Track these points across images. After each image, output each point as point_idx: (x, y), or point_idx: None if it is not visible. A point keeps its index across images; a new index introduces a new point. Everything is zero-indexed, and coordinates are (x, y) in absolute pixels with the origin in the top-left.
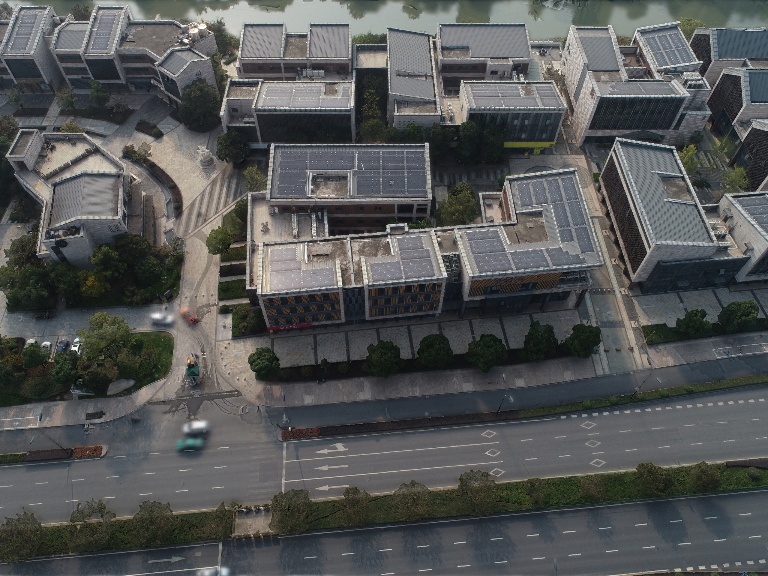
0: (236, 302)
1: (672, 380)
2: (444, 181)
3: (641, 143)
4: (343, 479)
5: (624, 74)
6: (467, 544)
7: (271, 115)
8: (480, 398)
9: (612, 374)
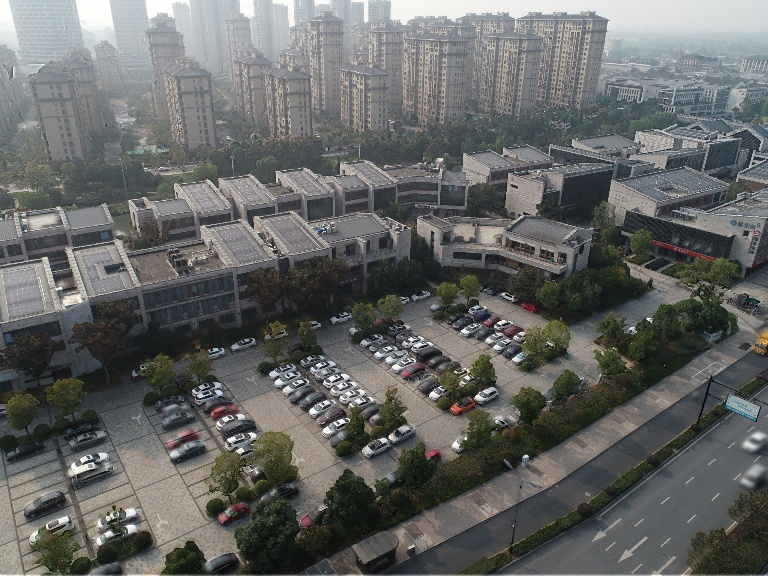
0: None
1: None
2: None
3: None
4: None
5: None
6: None
7: (571, 179)
8: None
9: None
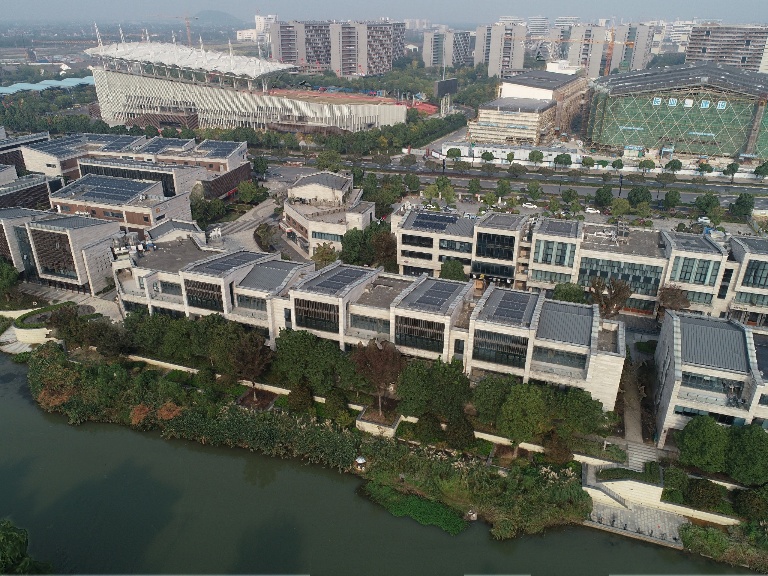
0: None
1: None
2: None
3: None
4: None
5: None
6: None
7: None
8: None
9: None
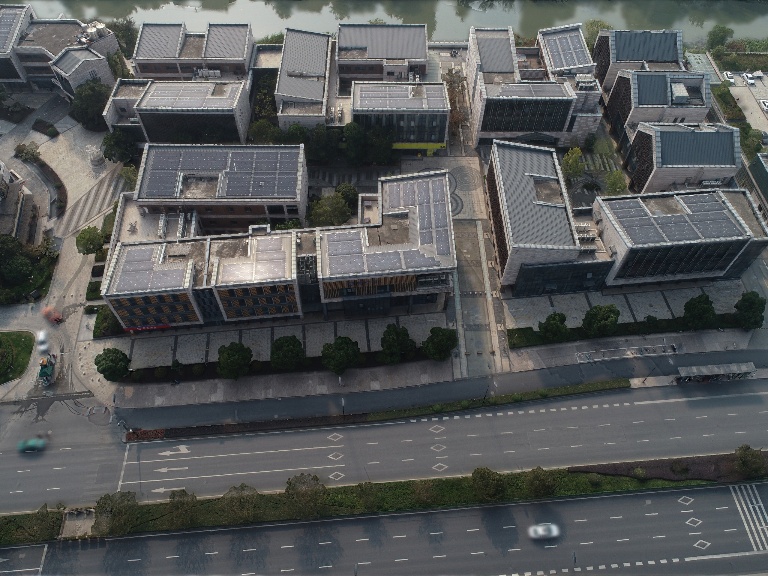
0: (103, 302)
1: (529, 384)
2: (333, 182)
3: (519, 145)
4: (180, 481)
5: (517, 76)
6: (294, 548)
7: (154, 115)
8: (332, 401)
9: (470, 378)
